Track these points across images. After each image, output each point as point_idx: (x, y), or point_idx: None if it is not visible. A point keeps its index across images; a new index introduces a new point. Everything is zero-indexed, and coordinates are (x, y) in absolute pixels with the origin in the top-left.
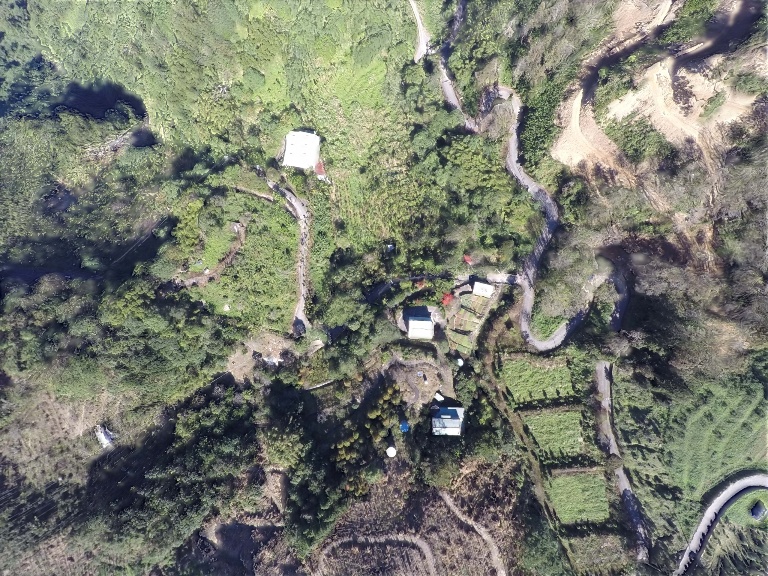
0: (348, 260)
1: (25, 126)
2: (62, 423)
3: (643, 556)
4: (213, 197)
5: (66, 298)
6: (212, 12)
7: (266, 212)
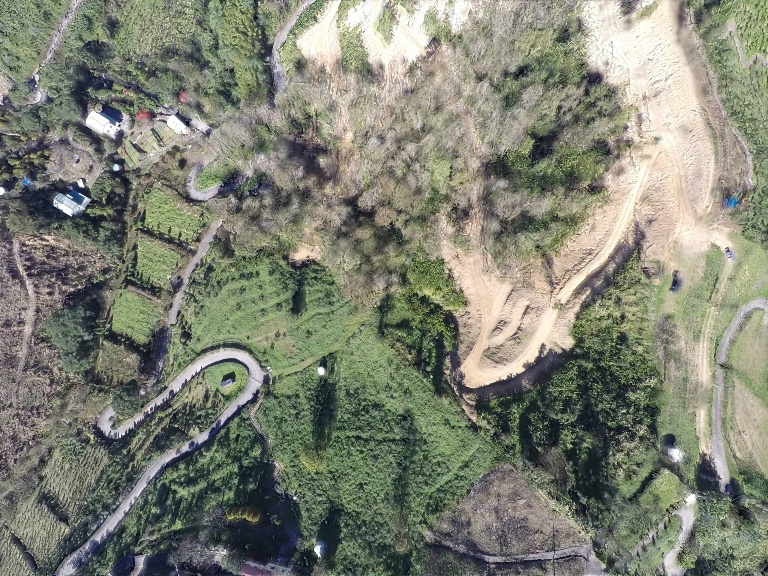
0: (102, 54)
1: None
2: None
3: (150, 383)
4: None
5: None
6: None
7: None
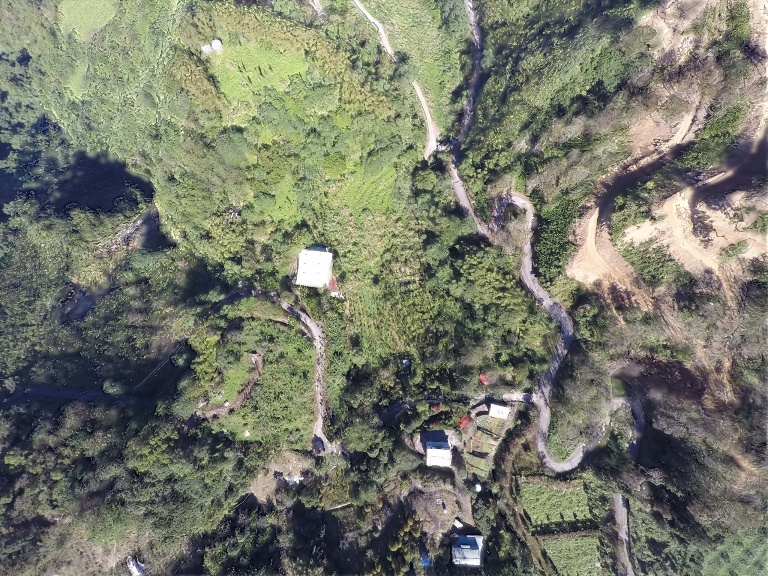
0: (364, 375)
1: (37, 226)
2: (96, 557)
3: None
4: (230, 334)
5: (91, 430)
6: (221, 146)
7: (282, 338)
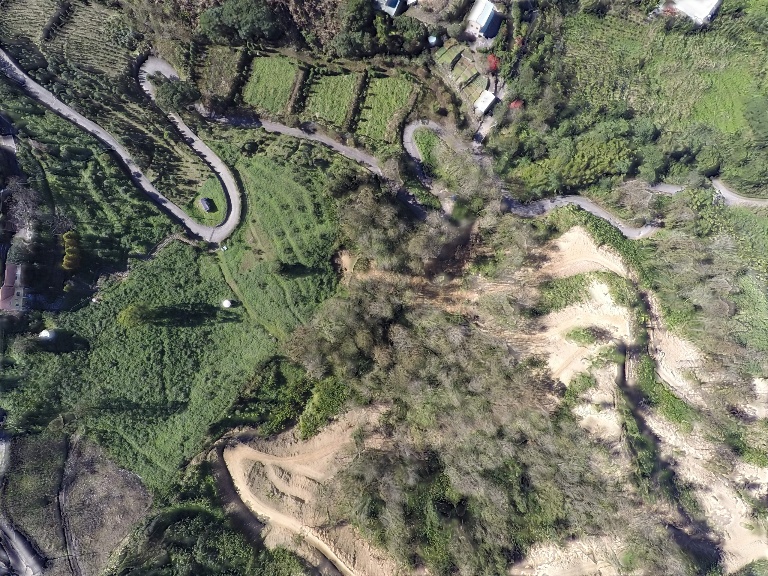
0: None
1: None
2: None
3: (201, 110)
4: None
5: None
6: None
7: None
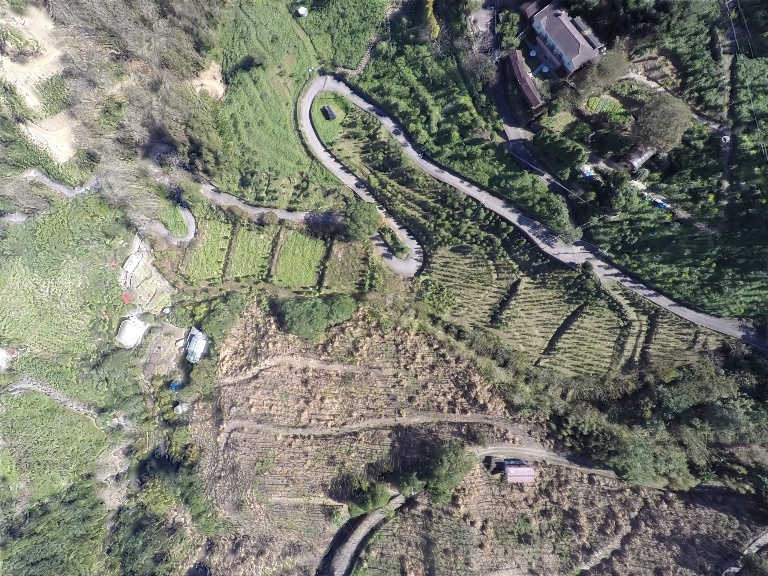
0: None
1: None
2: None
3: None
4: None
5: None
6: None
7: (4, 414)
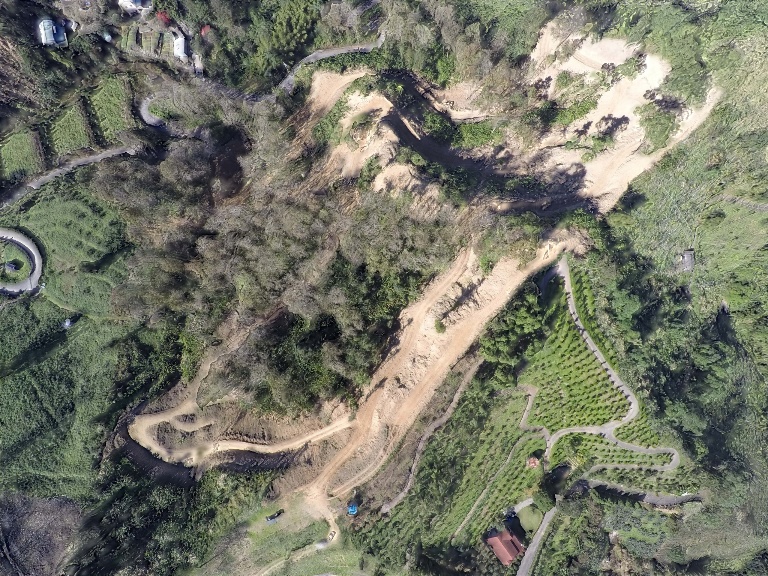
0: None
1: None
2: None
3: None
4: None
5: None
6: None
7: None
